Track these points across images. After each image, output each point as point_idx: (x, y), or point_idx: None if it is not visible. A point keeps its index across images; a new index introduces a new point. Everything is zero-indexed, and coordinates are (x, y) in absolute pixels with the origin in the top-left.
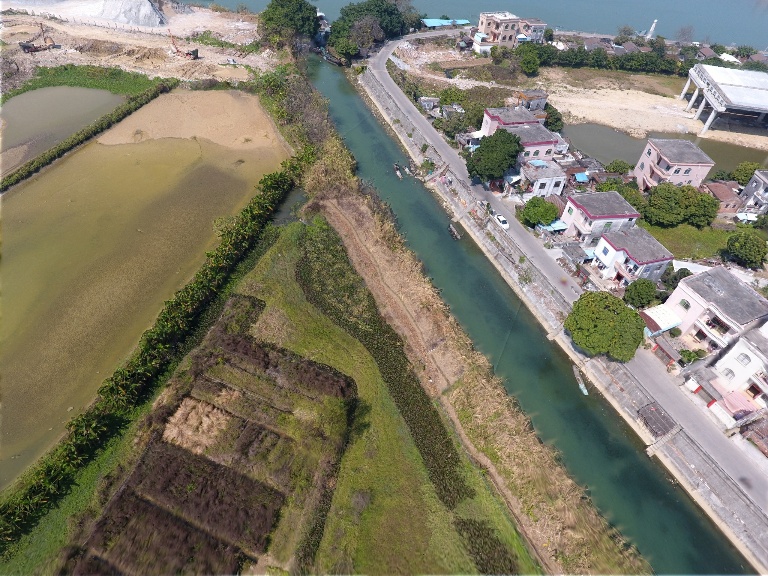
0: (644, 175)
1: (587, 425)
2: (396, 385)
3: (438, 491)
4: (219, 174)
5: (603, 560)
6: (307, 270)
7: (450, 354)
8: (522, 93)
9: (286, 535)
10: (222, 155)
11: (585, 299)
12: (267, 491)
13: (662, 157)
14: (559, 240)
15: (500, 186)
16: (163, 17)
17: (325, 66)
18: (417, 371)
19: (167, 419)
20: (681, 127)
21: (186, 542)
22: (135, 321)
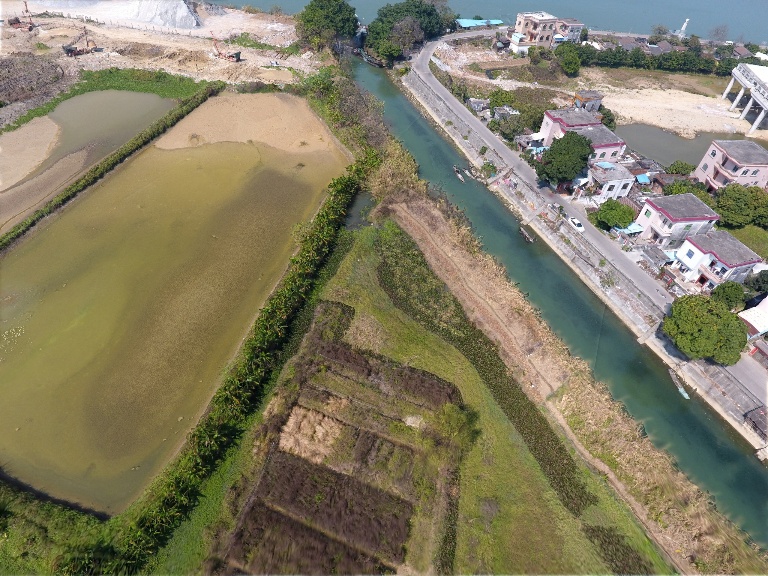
0: (708, 176)
1: (693, 429)
2: (499, 391)
3: (561, 498)
4: (282, 178)
5: (748, 566)
6: (389, 275)
7: (550, 359)
8: (578, 94)
9: (420, 544)
10: (281, 159)
11: (685, 303)
12: (394, 500)
13: (730, 158)
14: (635, 243)
15: (567, 188)
16: (198, 19)
17: (366, 68)
18: (517, 376)
19: (281, 428)
20: (729, 127)
21: (326, 553)
22: (227, 329)
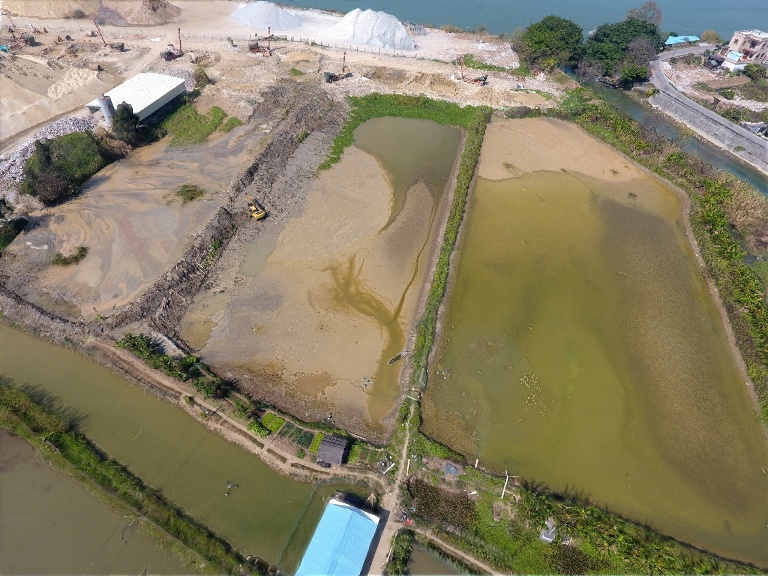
0: None
1: None
2: None
3: None
4: (628, 210)
5: None
6: None
7: None
8: None
9: None
10: (609, 189)
11: None
12: None
13: None
14: None
15: None
16: None
17: None
18: None
19: None
20: None
21: None
22: (721, 373)
